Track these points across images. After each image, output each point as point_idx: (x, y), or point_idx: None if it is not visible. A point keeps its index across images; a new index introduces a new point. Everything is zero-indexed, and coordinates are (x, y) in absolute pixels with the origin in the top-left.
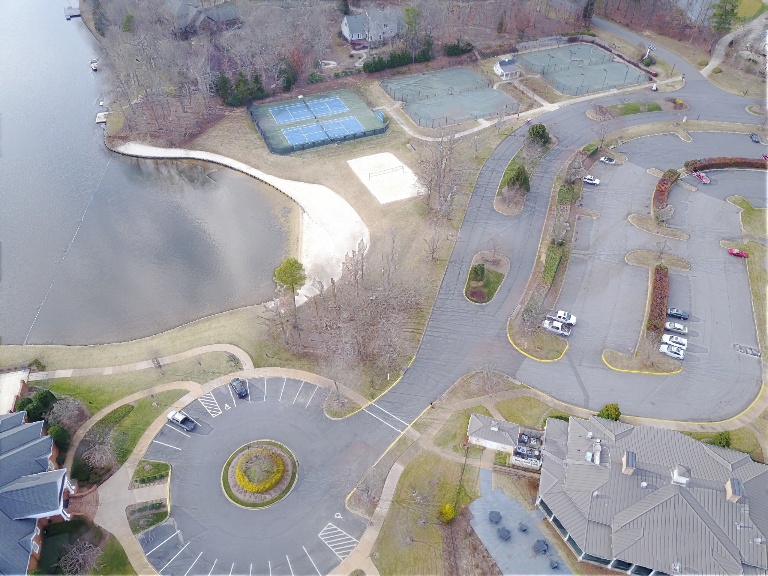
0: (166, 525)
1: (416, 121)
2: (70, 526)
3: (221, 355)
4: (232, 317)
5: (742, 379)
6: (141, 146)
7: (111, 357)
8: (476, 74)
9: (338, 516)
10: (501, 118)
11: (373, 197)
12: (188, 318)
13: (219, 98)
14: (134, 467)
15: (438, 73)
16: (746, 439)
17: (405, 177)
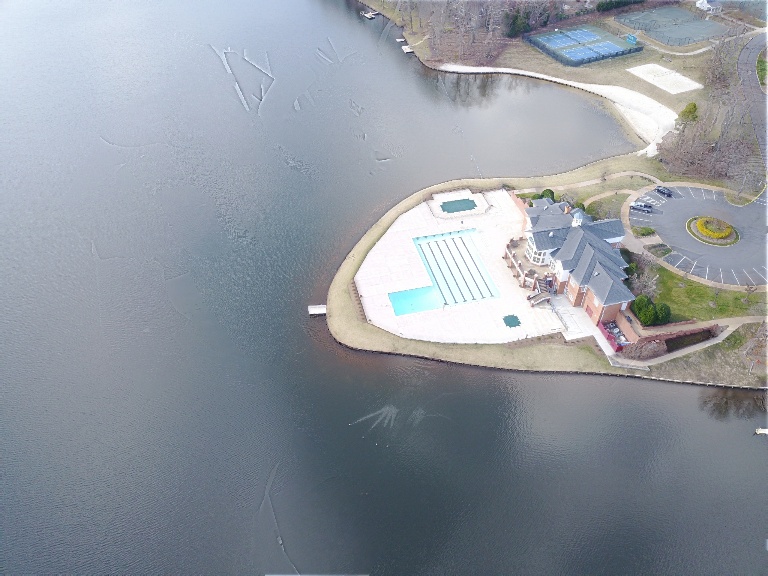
0: (675, 254)
1: (662, 42)
2: (623, 251)
3: (634, 177)
4: (616, 160)
5: None
6: (456, 66)
7: (554, 182)
8: (685, 11)
9: None
10: (739, 34)
11: (664, 90)
12: (582, 163)
13: (499, 31)
14: (630, 229)
15: (654, 11)
16: None
17: (678, 78)
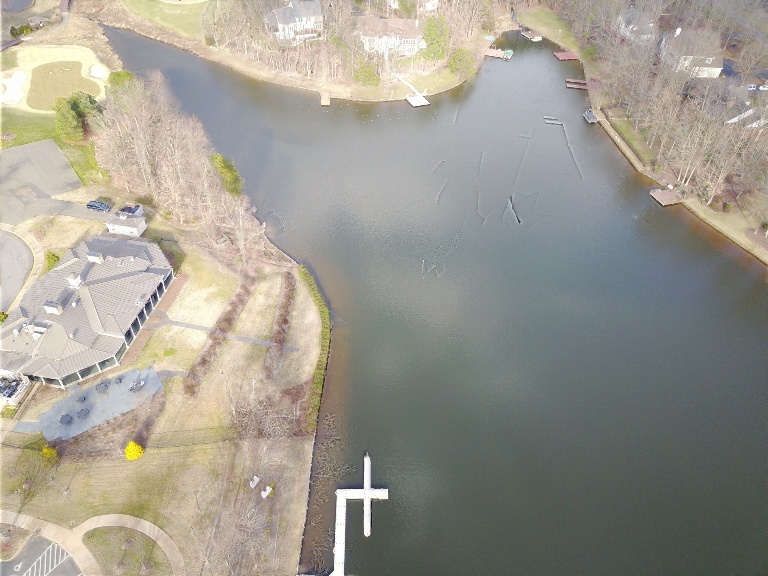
0: None
1: None
2: None
3: None
4: None
5: (1, 242)
6: None
7: None
8: None
9: (18, 567)
10: None
11: None
12: None
13: None
14: None
15: None
16: (55, 253)
17: None
